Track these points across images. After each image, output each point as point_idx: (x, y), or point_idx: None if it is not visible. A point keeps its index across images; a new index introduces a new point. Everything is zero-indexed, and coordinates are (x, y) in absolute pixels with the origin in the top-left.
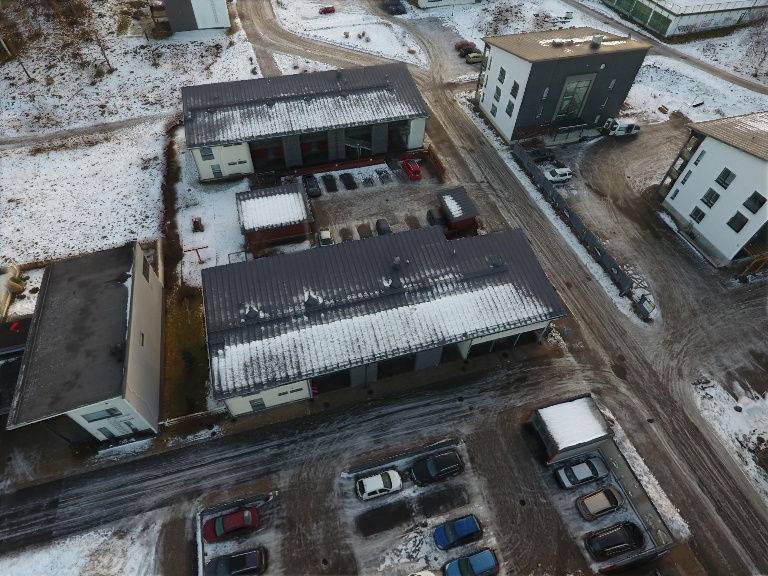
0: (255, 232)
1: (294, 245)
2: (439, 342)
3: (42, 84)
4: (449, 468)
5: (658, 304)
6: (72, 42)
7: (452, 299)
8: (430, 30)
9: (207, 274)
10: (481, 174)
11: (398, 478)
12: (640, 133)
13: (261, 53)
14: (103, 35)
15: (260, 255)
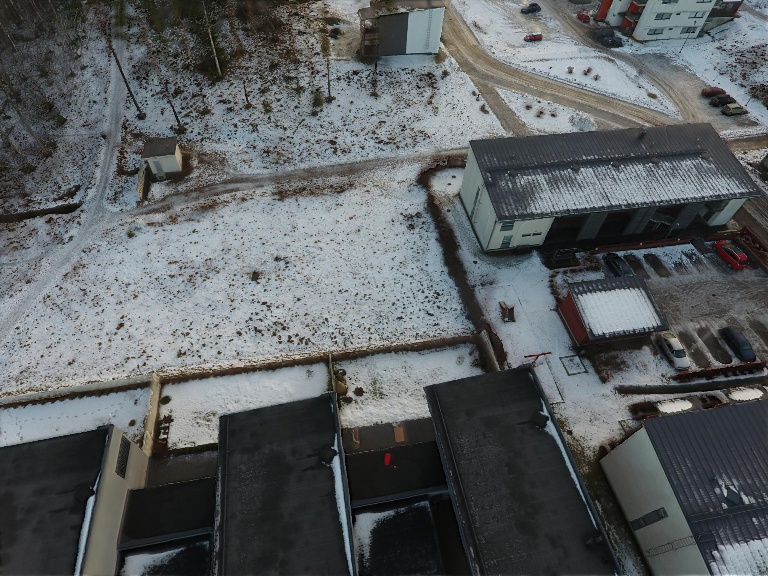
0: (605, 339)
1: (633, 351)
2: None
3: (261, 111)
4: None
5: None
6: (279, 62)
7: None
8: (661, 69)
9: (652, 428)
10: None
11: None
12: None
13: (483, 87)
14: (309, 56)
15: (598, 362)
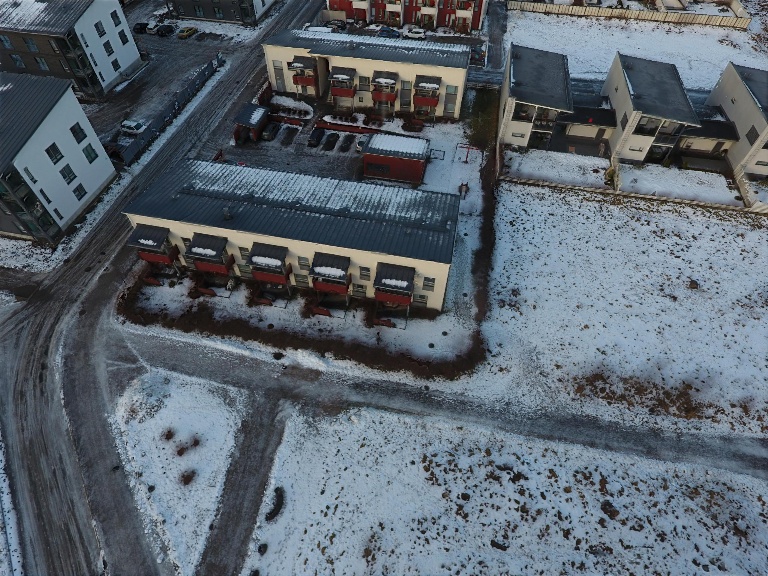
0: None
1: None
2: None
3: None
4: None
5: None
6: None
7: None
8: None
9: None
10: None
11: None
12: None
13: None
14: None
15: None
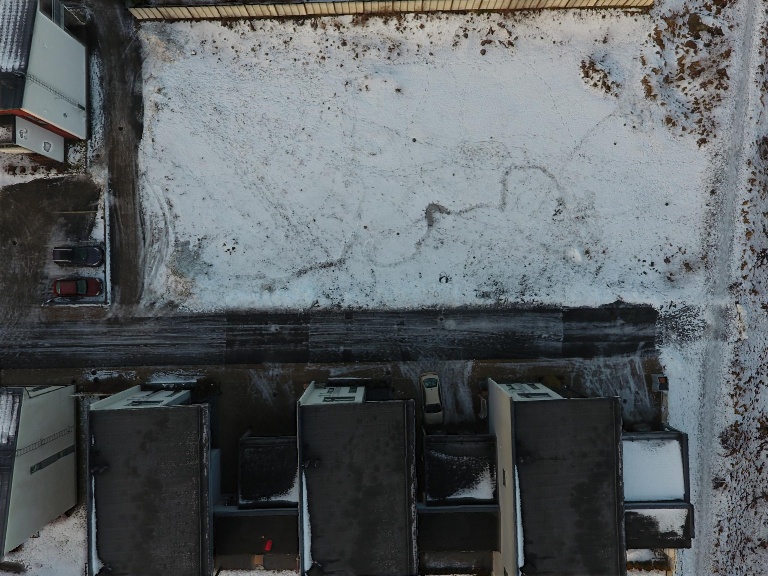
0: None
1: None
2: None
3: None
4: None
5: None
6: None
7: None
8: None
9: None
10: None
11: None
12: None
13: None
14: None
15: None
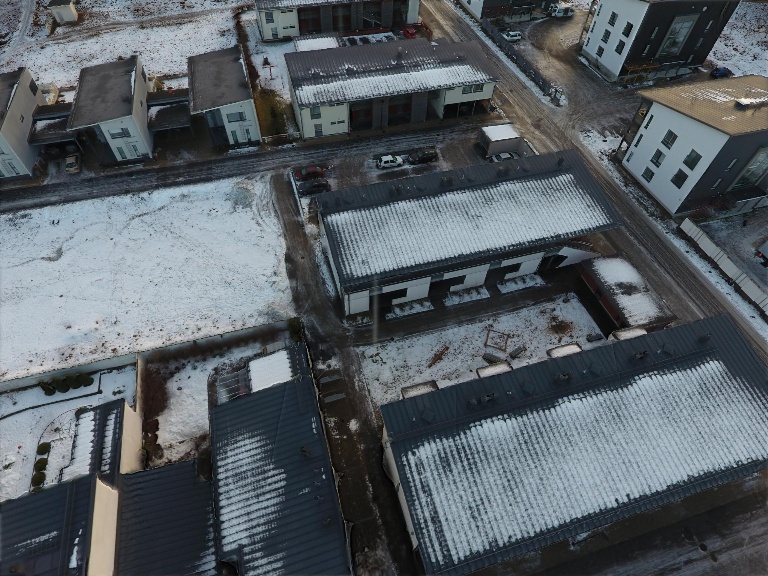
0: None
1: None
2: (424, 89)
3: None
4: (429, 152)
5: (567, 99)
6: None
7: (433, 71)
8: None
9: (287, 55)
10: (458, 38)
11: (401, 159)
12: (575, 16)
13: None
14: None
15: None
